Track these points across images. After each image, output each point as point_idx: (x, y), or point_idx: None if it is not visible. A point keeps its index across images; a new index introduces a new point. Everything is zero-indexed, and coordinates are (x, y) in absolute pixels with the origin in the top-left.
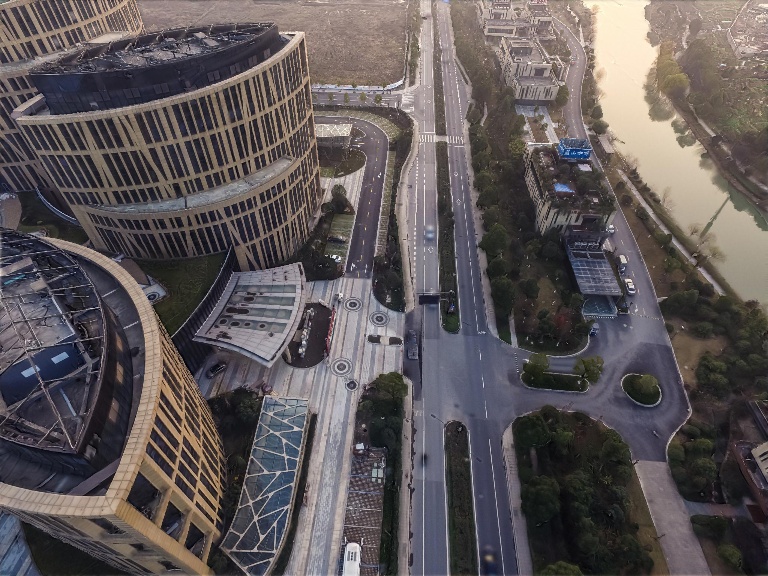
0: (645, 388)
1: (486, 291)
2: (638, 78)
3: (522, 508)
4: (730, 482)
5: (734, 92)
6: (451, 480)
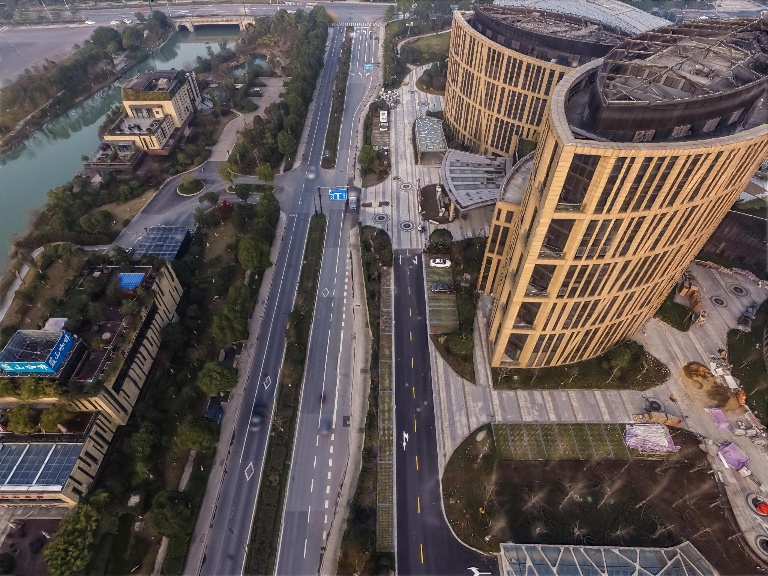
0: None
1: (277, 247)
2: None
3: None
4: None
5: None
6: None
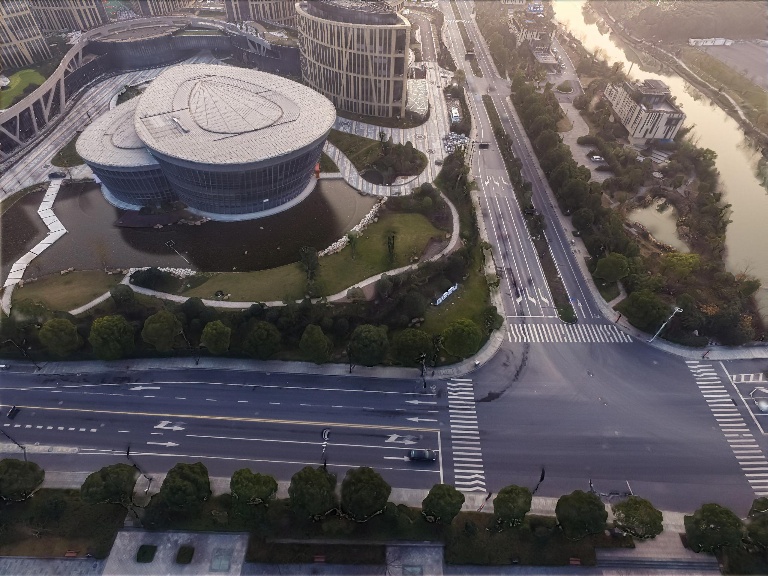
0: (565, 85)
1: (494, 67)
2: (579, 5)
3: (515, 99)
4: (596, 105)
5: (634, 5)
6: (486, 104)
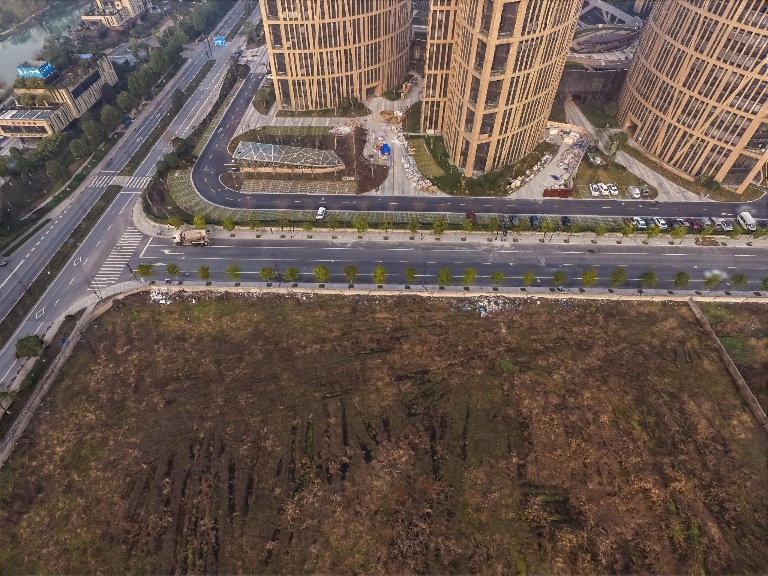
0: None
1: None
2: None
3: None
4: None
5: None
6: None
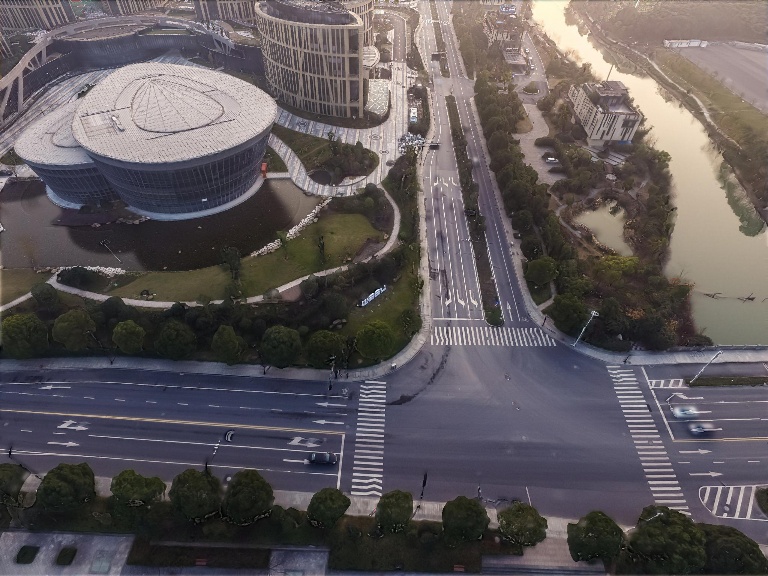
0: (531, 86)
1: (463, 67)
2: (562, 6)
3: (476, 99)
4: None
5: (615, 6)
6: None
